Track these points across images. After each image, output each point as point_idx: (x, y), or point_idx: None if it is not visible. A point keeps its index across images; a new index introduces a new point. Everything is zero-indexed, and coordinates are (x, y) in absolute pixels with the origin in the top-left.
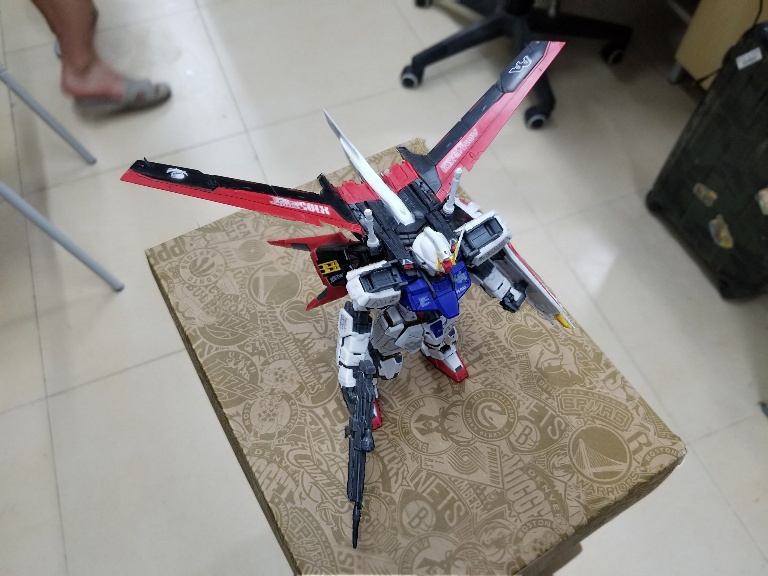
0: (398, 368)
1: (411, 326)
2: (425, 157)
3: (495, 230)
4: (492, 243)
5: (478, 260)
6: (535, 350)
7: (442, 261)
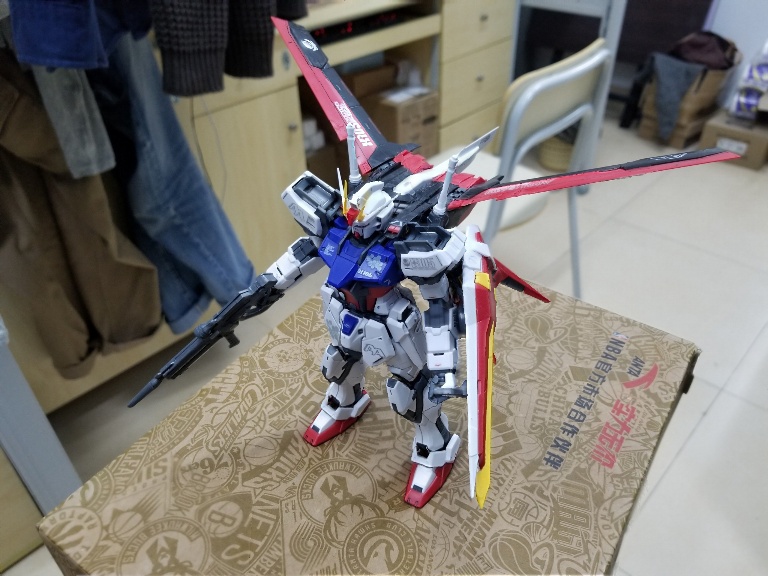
0: (327, 361)
1: (335, 298)
2: (497, 182)
3: (440, 247)
4: (423, 253)
5: (403, 262)
6: (503, 575)
7: (350, 205)
